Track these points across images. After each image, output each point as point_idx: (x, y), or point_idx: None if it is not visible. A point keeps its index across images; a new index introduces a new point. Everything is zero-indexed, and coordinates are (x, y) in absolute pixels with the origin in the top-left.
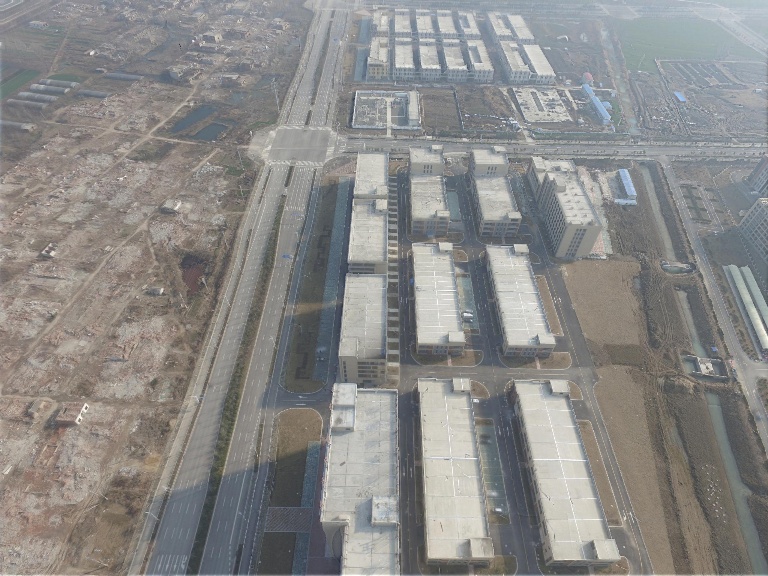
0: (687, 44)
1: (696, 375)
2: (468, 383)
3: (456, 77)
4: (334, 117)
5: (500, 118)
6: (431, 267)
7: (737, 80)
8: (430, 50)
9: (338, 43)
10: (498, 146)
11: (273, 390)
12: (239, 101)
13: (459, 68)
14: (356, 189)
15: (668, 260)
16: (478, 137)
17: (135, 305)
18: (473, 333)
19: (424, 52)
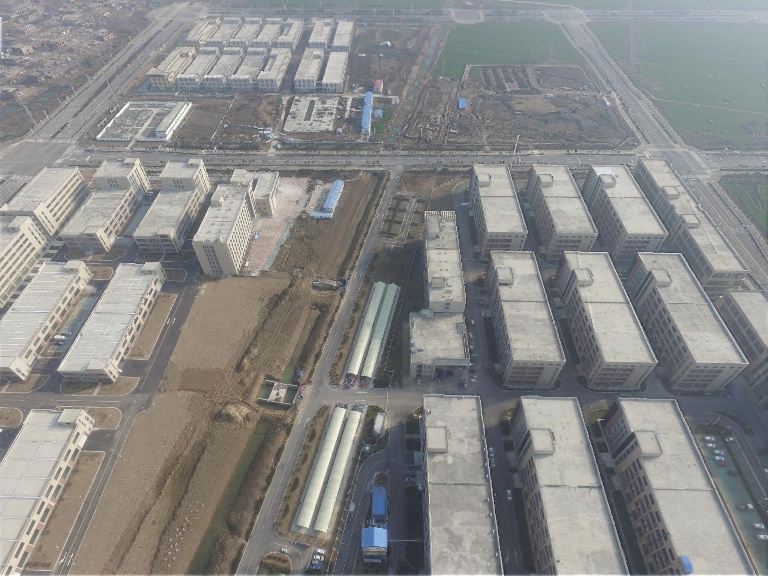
0: (513, 48)
1: (263, 402)
2: None
3: (240, 86)
4: (87, 129)
5: (259, 128)
6: (45, 287)
7: (537, 85)
8: (231, 59)
9: (147, 53)
10: (194, 159)
11: None
12: (6, 114)
13: (241, 77)
14: (12, 205)
15: (327, 277)
16: (219, 148)
17: None
18: (54, 356)
19: (222, 61)
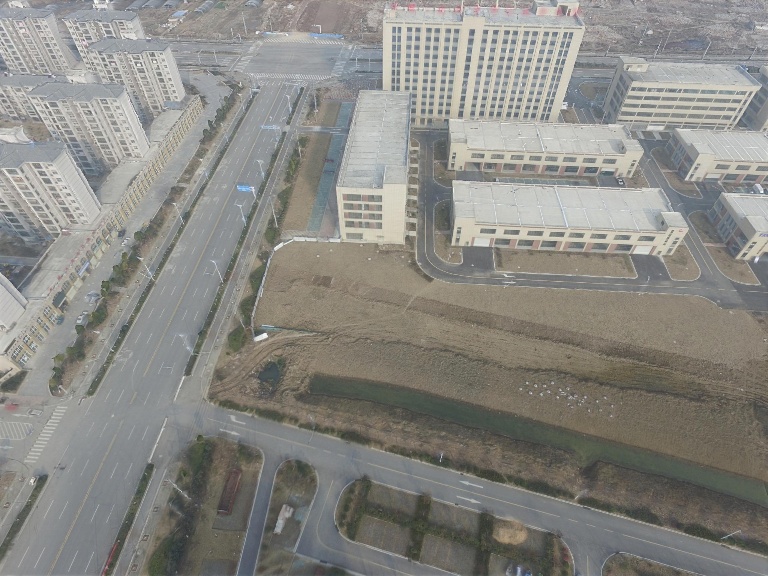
0: None
1: None
2: (636, 149)
3: None
4: None
5: None
6: None
7: None
8: None
9: None
10: None
11: (577, 79)
12: None
13: None
14: None
15: None
16: None
17: (628, 28)
18: None
19: None
